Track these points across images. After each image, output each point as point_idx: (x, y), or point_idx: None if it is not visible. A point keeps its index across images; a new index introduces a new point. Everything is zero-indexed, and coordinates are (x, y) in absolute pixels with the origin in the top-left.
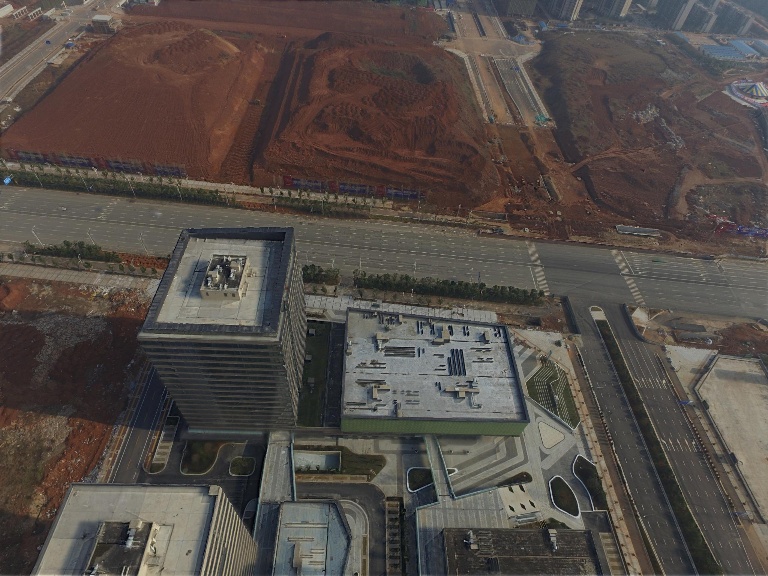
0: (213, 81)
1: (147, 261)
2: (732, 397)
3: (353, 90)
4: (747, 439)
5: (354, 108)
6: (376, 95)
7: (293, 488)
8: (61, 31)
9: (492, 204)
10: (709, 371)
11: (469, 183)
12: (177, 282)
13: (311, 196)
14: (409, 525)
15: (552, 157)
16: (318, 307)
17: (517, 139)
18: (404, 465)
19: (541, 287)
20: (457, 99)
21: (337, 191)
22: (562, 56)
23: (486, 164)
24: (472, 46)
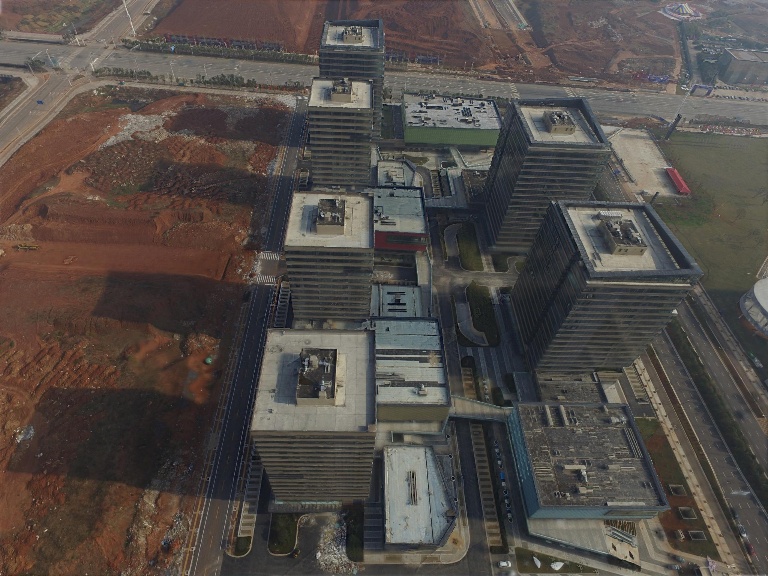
0: None
1: None
2: (627, 143)
3: (388, 3)
4: (632, 157)
5: (391, 12)
6: (405, 5)
7: None
8: None
9: (487, 66)
10: (616, 134)
11: (471, 53)
12: (329, 37)
13: None
14: (443, 178)
15: (528, 45)
16: None
17: (504, 36)
18: (439, 161)
19: None
20: (461, 10)
21: None
22: None
23: (482, 44)
24: None
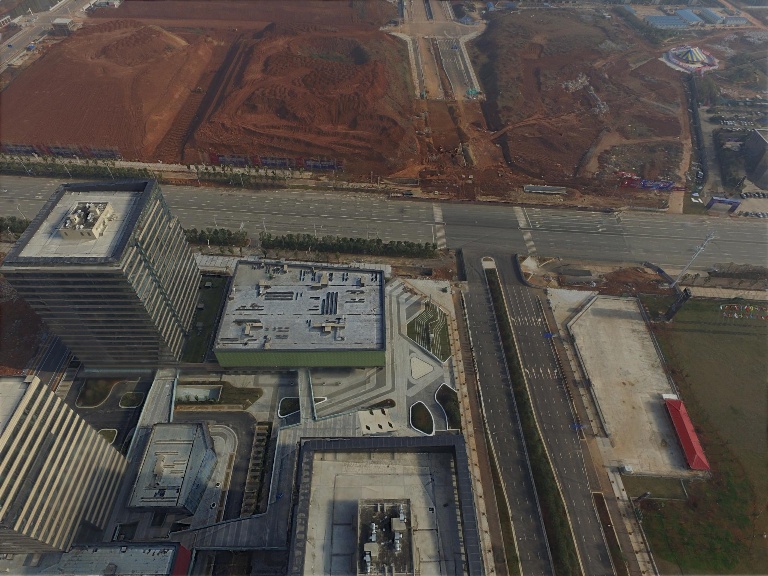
0: (155, 72)
1: None
2: (602, 331)
3: (285, 73)
4: (608, 367)
5: (283, 89)
6: (306, 76)
7: (170, 414)
8: (25, 36)
9: (407, 171)
10: (585, 310)
11: (386, 152)
12: (45, 227)
13: (235, 171)
14: (274, 444)
15: (475, 127)
16: (224, 266)
17: (444, 112)
18: (279, 396)
19: (439, 242)
20: (387, 77)
21: (259, 165)
22: (502, 33)
23: (405, 135)
24: (417, 29)
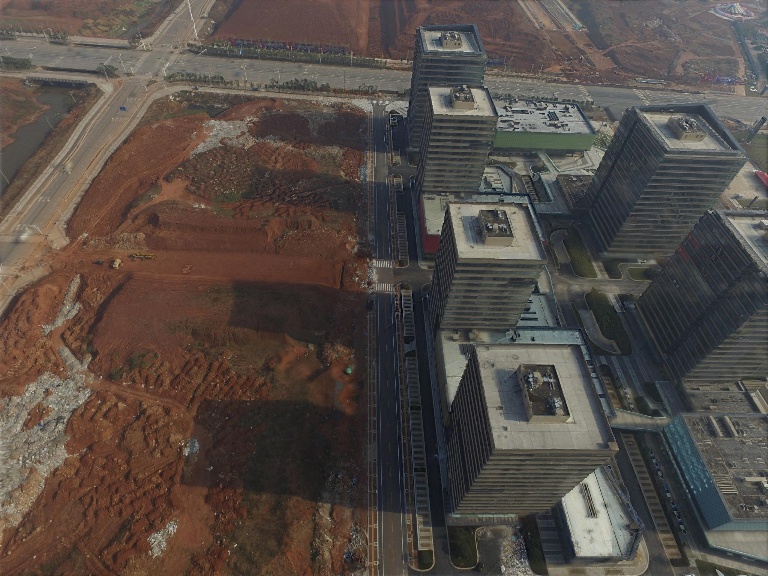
0: (346, 1)
1: (346, 91)
2: None
3: (446, 5)
4: None
5: (451, 14)
6: (463, 7)
7: None
8: None
9: (552, 68)
10: None
11: (536, 56)
12: (427, 43)
13: None
14: (536, 183)
15: (588, 47)
16: None
17: (562, 38)
18: (528, 165)
19: None
20: (518, 12)
21: None
22: None
23: (545, 46)
24: None
